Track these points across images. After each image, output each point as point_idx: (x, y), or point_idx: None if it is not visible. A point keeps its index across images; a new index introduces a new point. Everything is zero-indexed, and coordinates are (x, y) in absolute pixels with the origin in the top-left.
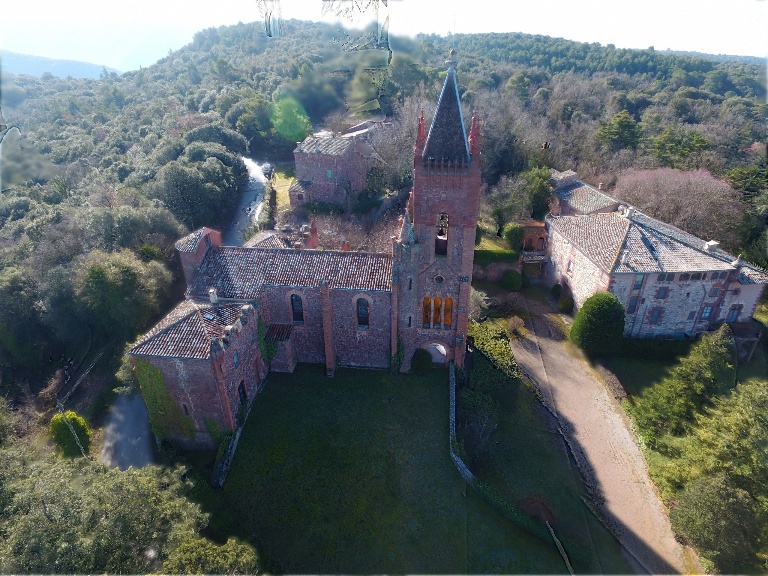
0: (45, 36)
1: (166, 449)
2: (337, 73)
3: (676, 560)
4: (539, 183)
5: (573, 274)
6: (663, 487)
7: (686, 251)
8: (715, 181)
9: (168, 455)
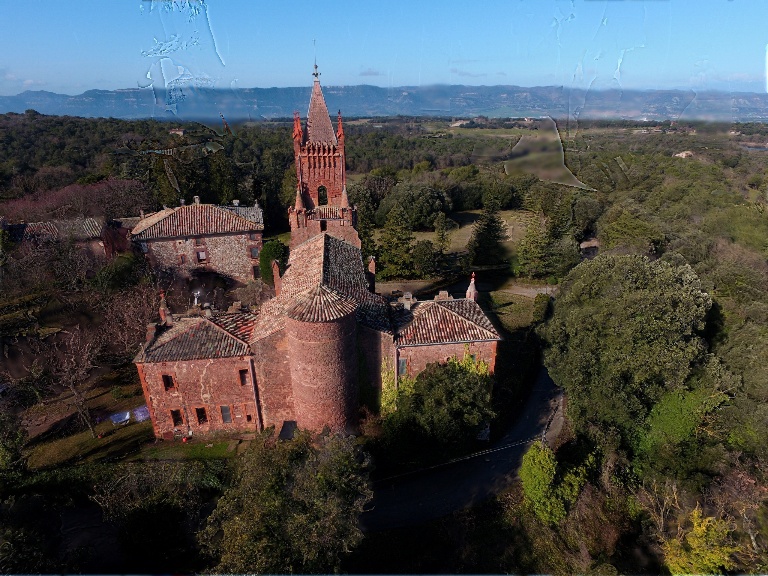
0: (428, 5)
1: (497, 411)
2: (208, 81)
3: (428, 283)
4: (2, 234)
5: (210, 259)
6: (403, 272)
7: (241, 209)
8: (129, 182)
9: (501, 406)
